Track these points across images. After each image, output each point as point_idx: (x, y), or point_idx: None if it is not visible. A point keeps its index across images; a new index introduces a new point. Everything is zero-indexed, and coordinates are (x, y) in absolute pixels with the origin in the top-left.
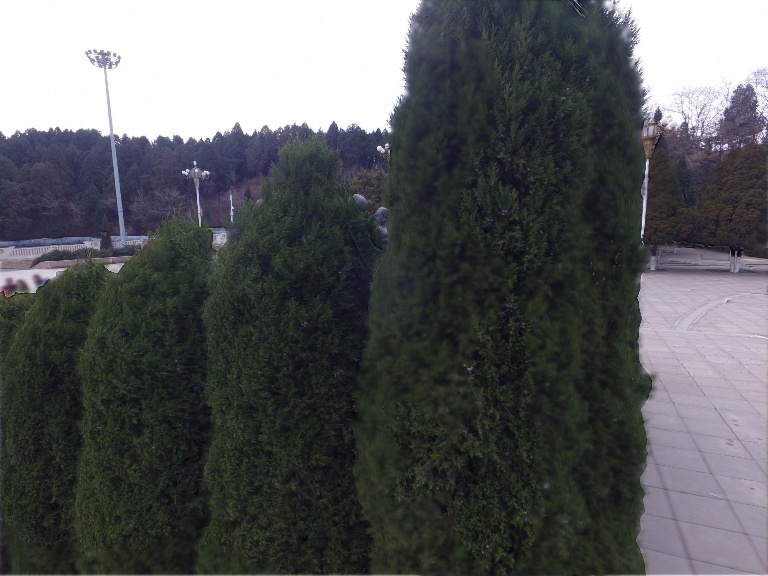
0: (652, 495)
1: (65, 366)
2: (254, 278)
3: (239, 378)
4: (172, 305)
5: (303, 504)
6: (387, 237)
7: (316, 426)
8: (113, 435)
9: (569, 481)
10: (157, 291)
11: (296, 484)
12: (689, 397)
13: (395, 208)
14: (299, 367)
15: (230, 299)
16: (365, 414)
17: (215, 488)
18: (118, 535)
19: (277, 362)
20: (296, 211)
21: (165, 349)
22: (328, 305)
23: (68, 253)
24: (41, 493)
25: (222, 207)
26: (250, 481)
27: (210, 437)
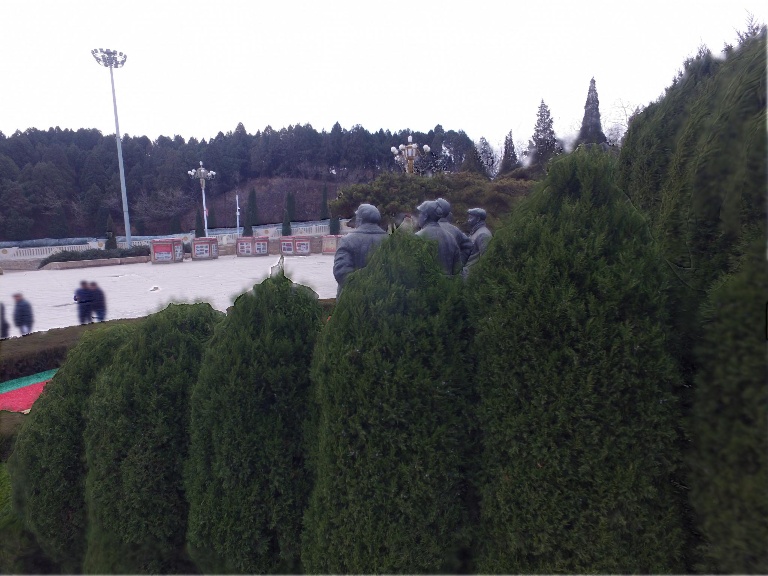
0: None
1: (281, 385)
2: (572, 298)
3: (548, 404)
4: (439, 324)
5: (624, 538)
6: (468, 242)
7: (640, 456)
8: (376, 461)
9: None
10: (414, 308)
11: (624, 518)
12: None
13: (765, 226)
14: (625, 393)
15: (540, 320)
16: (718, 445)
17: (515, 520)
18: (388, 568)
19: (607, 388)
20: (602, 226)
21: (433, 371)
22: (660, 328)
23: (77, 254)
24: (258, 519)
25: (228, 207)
26: (564, 514)
27: (477, 463)
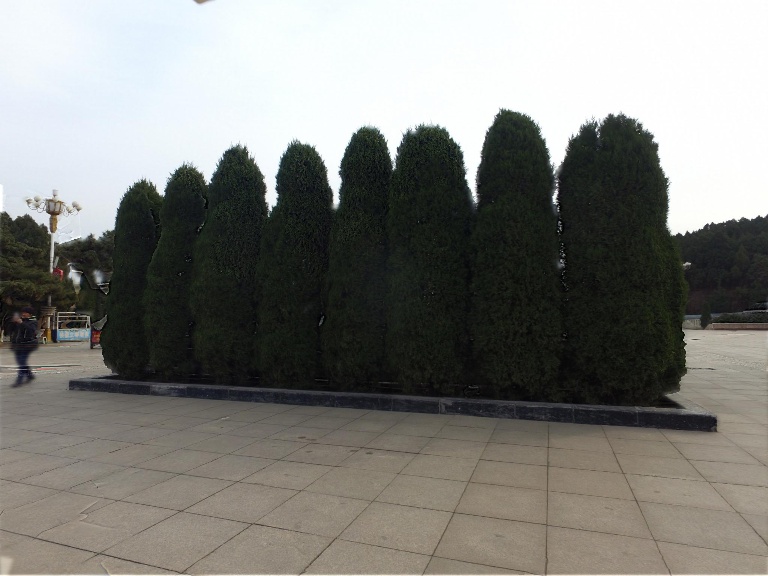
0: (241, 407)
1: None
2: None
3: None
4: None
5: None
6: None
7: None
8: None
9: (112, 278)
10: None
11: None
12: (466, 448)
13: None
14: None
15: None
16: None
17: None
18: None
19: None
20: None
21: None
22: None
23: (737, 316)
24: None
25: None
26: None
27: None
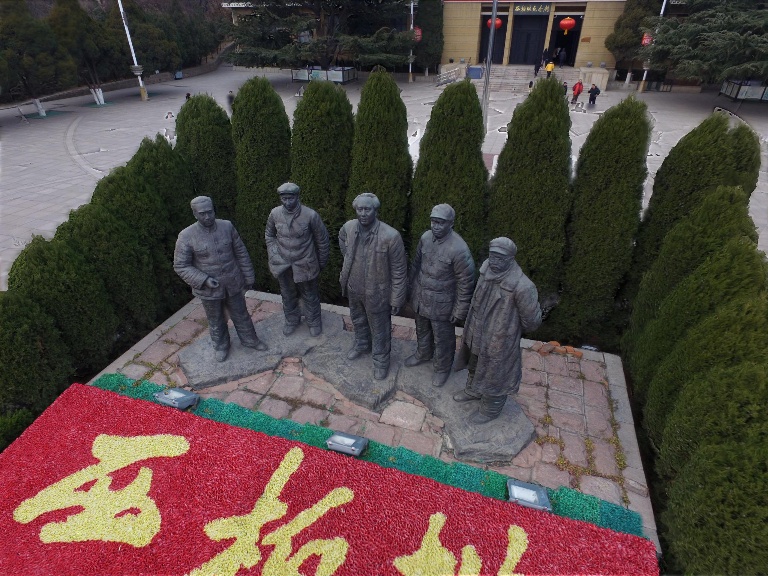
0: None
1: None
2: None
3: None
4: None
5: None
6: None
7: None
8: None
9: None
10: None
11: None
12: None
13: None
14: None
15: None
16: None
17: None
18: None
19: None
20: None
21: None
22: None
23: None
24: None
25: None
26: None
27: None
